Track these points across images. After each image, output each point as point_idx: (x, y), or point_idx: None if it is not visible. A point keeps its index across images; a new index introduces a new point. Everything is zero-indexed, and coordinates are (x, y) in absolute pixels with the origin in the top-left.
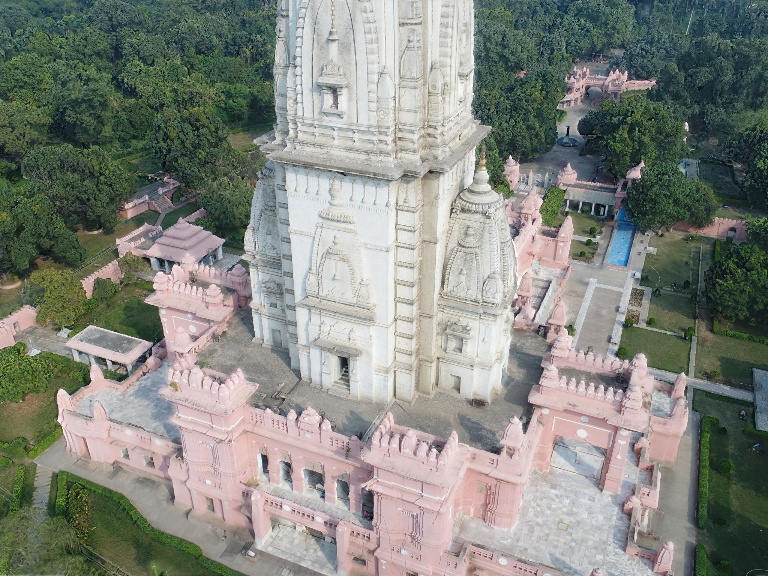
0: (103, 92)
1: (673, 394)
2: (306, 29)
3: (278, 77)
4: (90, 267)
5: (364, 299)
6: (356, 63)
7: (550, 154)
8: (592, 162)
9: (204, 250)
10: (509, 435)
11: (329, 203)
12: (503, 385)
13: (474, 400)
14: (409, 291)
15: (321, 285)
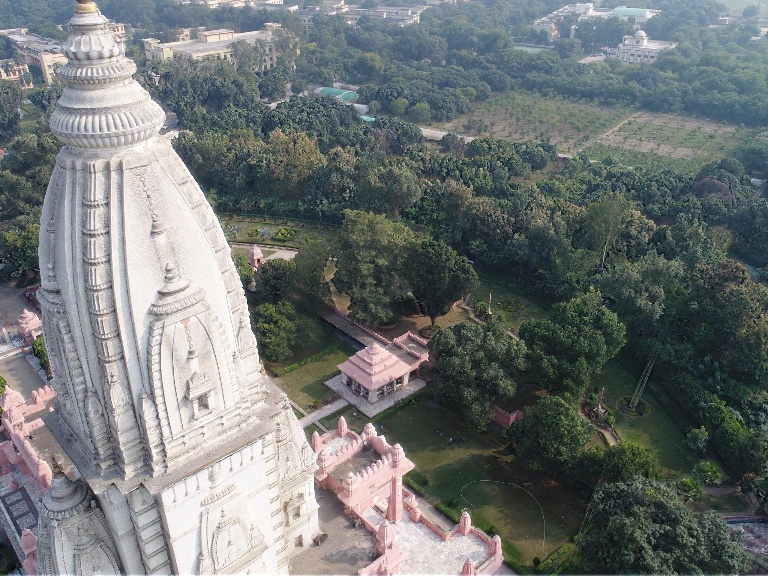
0: None
1: (343, 434)
2: (164, 362)
3: (118, 418)
4: None
5: (257, 539)
6: (217, 364)
7: None
8: (9, 293)
9: None
10: (388, 535)
11: (210, 489)
12: None
13: (320, 540)
14: (277, 504)
15: (217, 561)
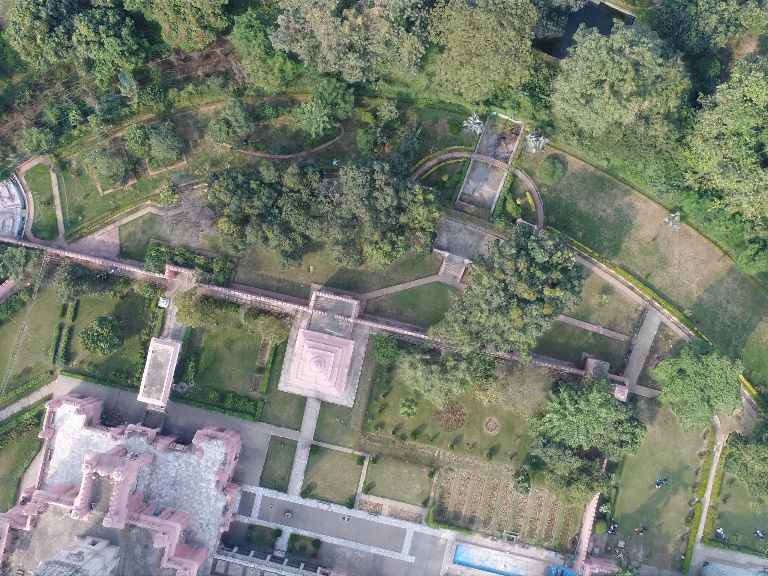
0: (588, 126)
1: None
2: None
3: None
4: (306, 265)
5: None
6: None
7: None
8: None
9: (312, 387)
10: None
11: None
12: None
13: None
14: None
15: None
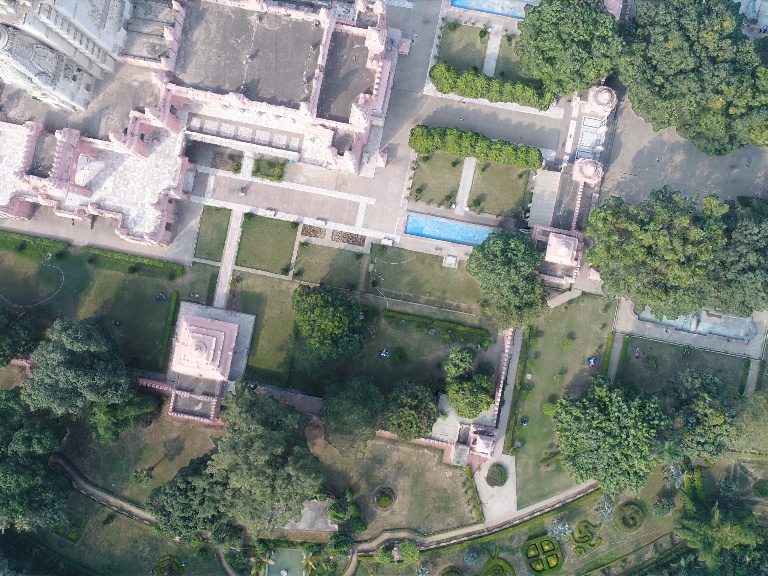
0: None
1: None
2: None
3: None
4: None
5: None
6: None
7: (735, 155)
8: None
9: None
10: None
11: None
12: (62, 109)
13: None
14: None
15: None
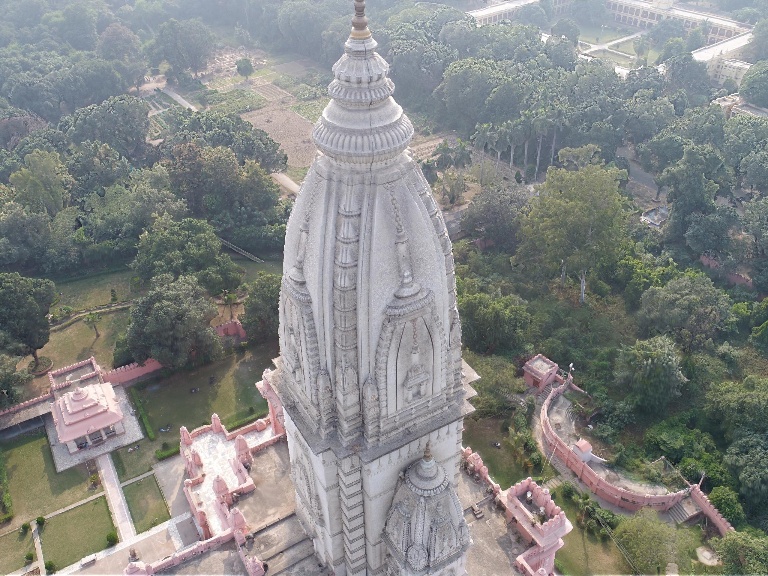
0: None
1: None
2: None
3: None
4: None
5: None
6: None
7: None
8: None
9: None
10: None
11: None
12: None
13: None
14: None
15: None
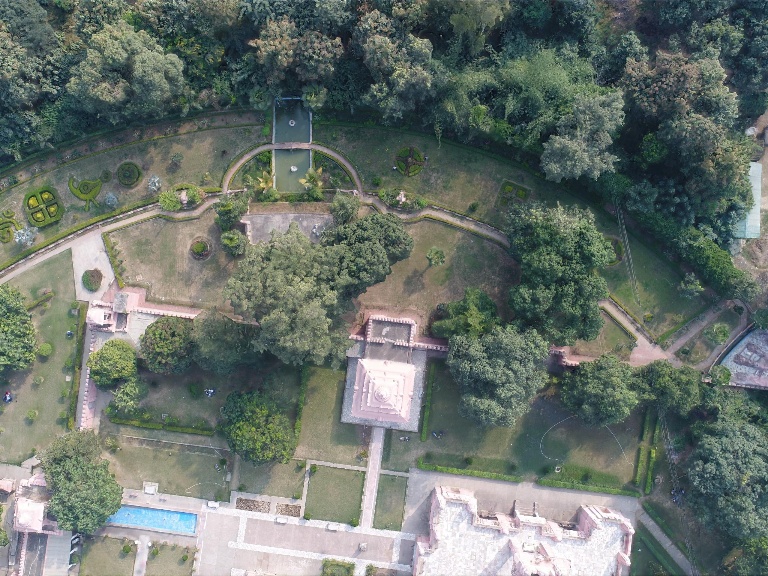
0: None
1: None
2: None
3: None
4: None
5: None
6: None
7: None
8: None
9: None
10: None
11: None
12: None
13: None
14: None
15: None
